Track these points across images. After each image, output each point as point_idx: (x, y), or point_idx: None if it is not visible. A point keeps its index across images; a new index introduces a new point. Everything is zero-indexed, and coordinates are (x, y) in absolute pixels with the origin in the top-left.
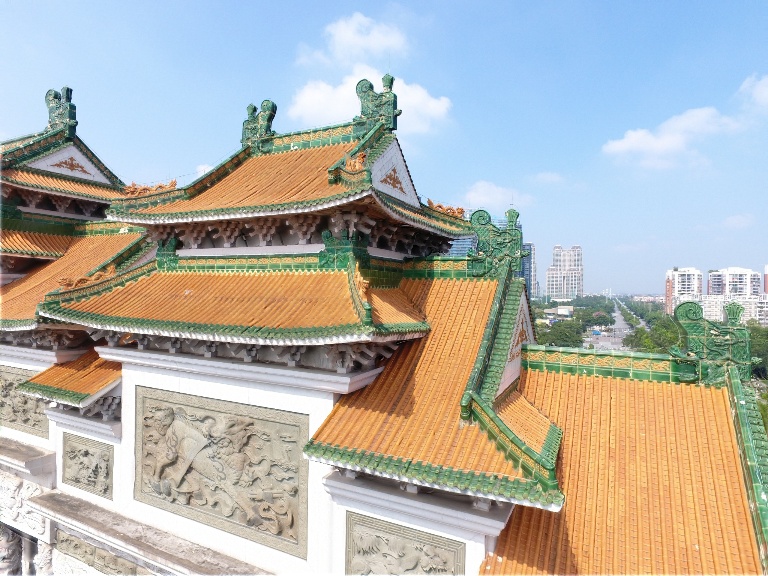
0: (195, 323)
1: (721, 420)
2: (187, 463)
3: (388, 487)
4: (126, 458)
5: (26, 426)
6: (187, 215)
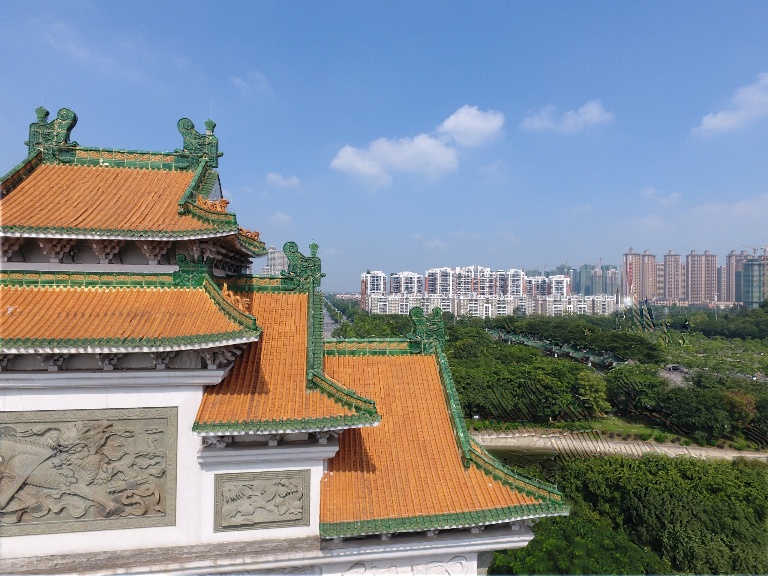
0: (53, 338)
1: (433, 372)
2: (20, 480)
3: (253, 447)
4: None
5: None
6: (14, 230)
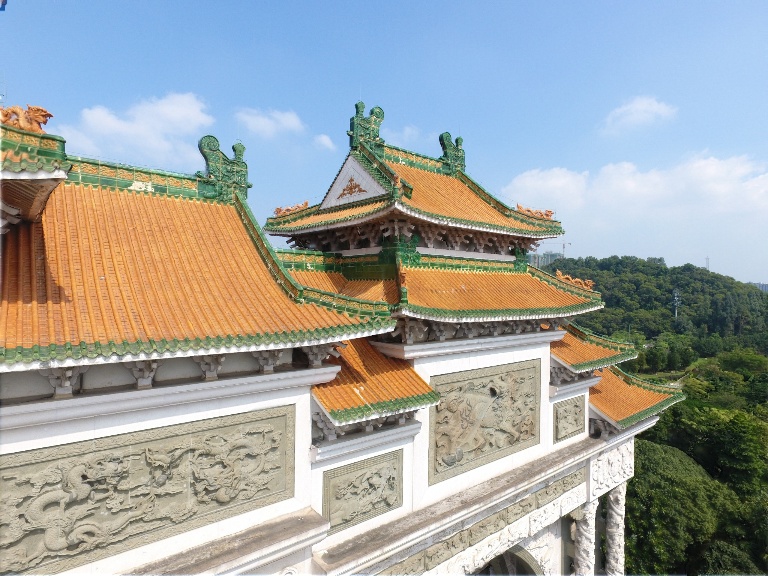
0: (520, 309)
1: None
2: (479, 423)
3: None
4: (421, 452)
5: (231, 506)
6: (470, 223)
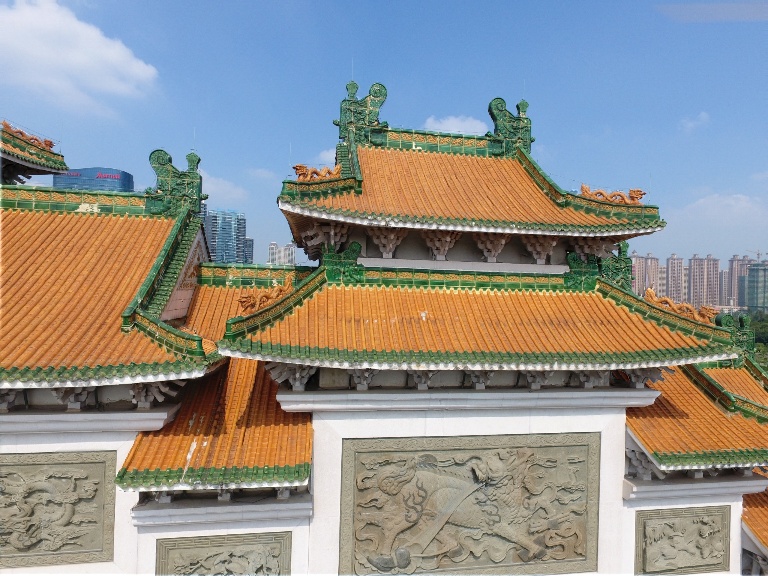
0: None
1: None
2: (443, 518)
3: (678, 479)
4: (323, 541)
5: (30, 555)
6: (432, 221)
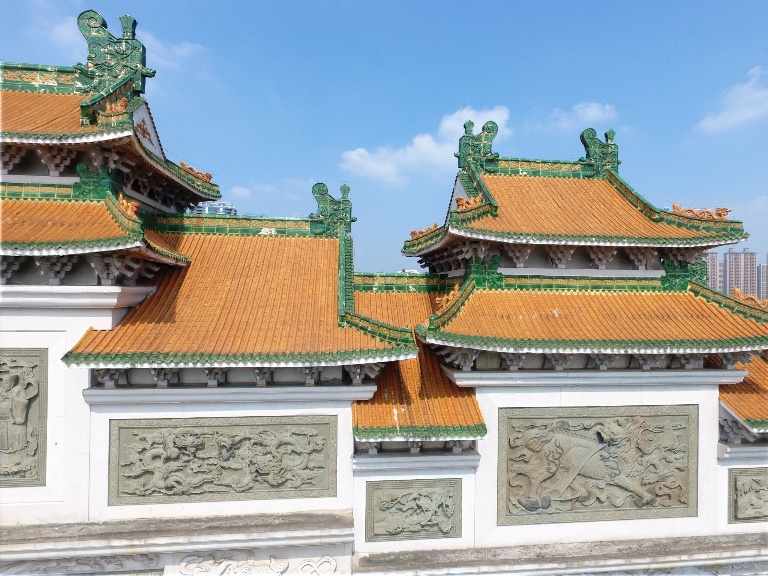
0: (631, 340)
1: None
2: (576, 471)
3: (763, 443)
4: (485, 486)
5: (280, 490)
6: (562, 238)
